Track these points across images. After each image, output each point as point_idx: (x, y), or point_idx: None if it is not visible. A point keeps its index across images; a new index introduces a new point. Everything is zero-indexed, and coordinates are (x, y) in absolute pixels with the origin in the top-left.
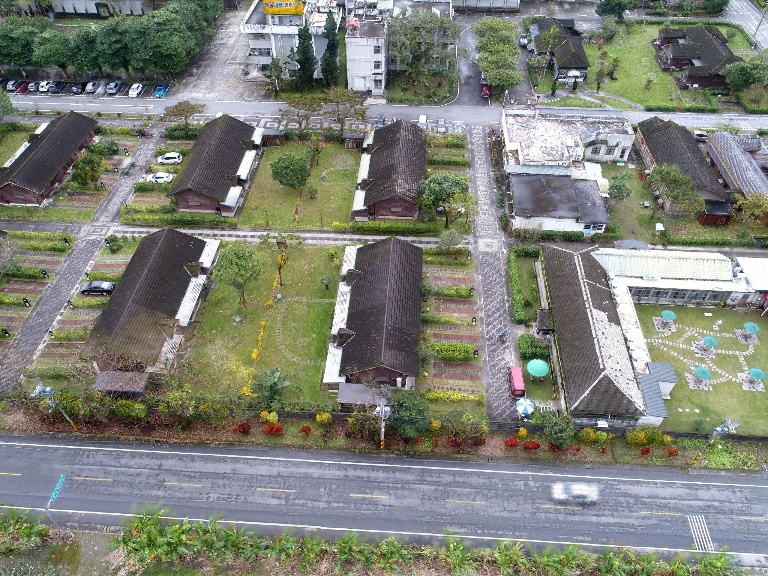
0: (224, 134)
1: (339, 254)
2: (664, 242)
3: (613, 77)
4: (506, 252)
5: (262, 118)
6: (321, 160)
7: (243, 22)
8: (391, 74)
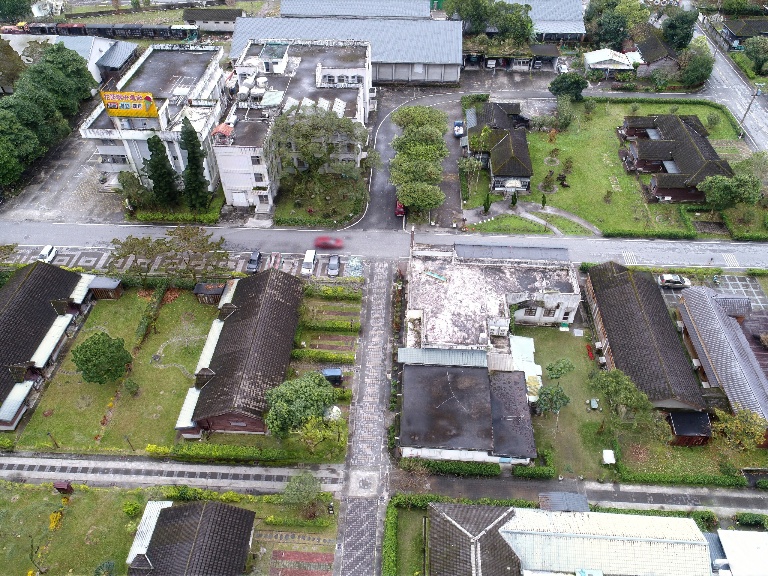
0: (27, 294)
1: (145, 504)
2: (615, 478)
3: (565, 184)
4: (387, 498)
5: (105, 251)
6: (163, 324)
7: (87, 124)
8: (287, 180)
